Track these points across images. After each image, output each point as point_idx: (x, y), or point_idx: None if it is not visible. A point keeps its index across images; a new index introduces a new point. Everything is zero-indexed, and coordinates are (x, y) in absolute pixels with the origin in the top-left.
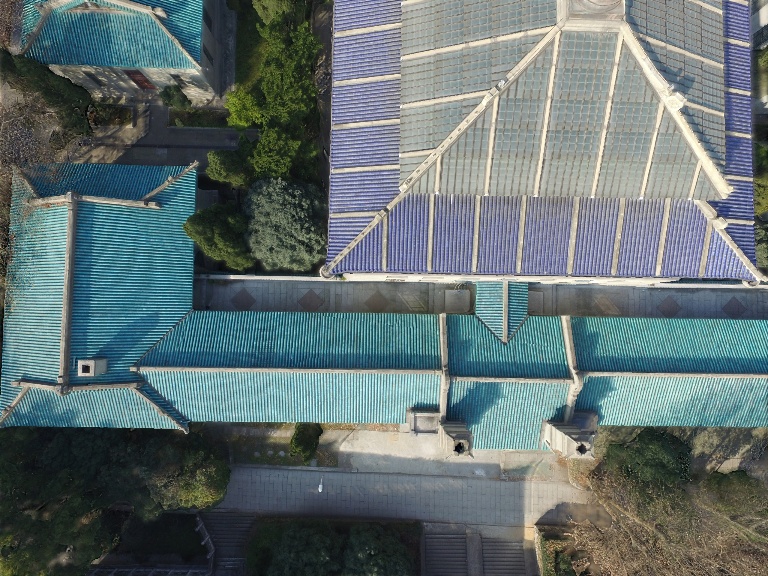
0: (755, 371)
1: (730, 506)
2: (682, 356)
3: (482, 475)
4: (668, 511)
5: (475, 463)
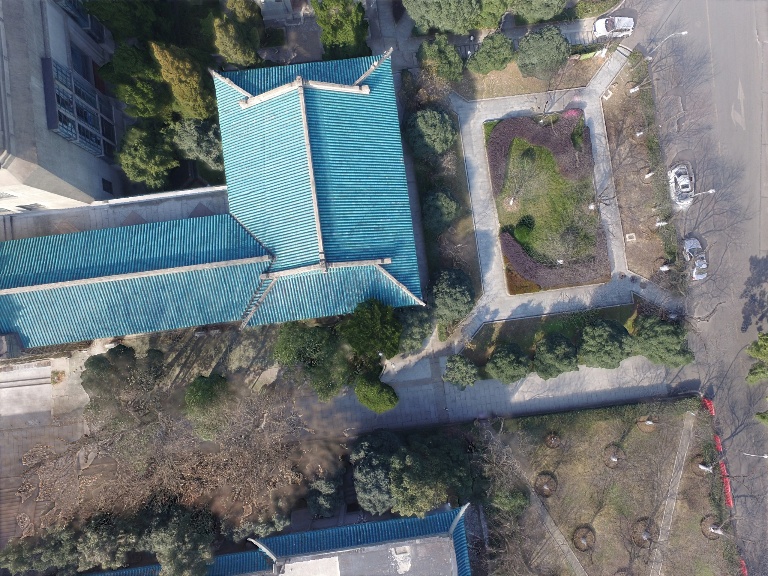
0: (160, 268)
1: (187, 410)
2: (90, 264)
3: (35, 424)
4: (94, 422)
5: (27, 413)
